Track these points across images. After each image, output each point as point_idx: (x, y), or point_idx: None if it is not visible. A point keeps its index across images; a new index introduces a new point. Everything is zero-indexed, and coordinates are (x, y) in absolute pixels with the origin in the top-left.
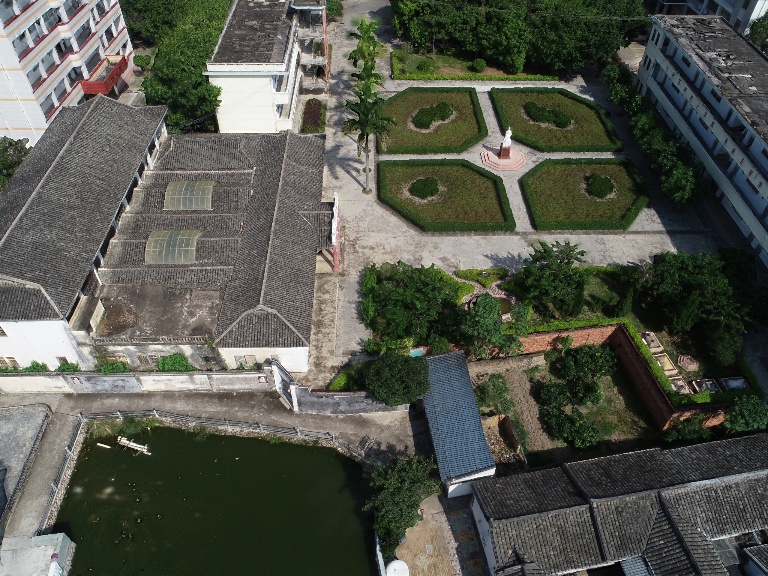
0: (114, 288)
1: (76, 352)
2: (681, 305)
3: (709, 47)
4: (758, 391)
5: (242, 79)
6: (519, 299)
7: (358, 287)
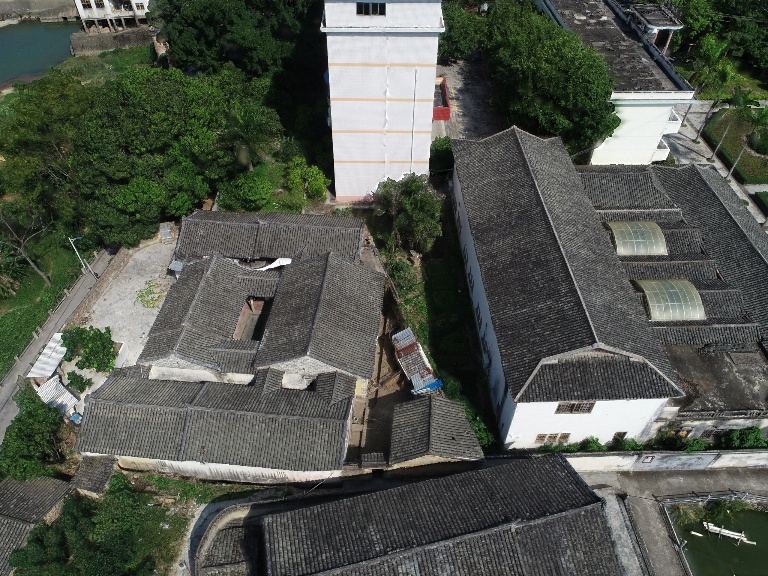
0: None
1: (644, 427)
2: None
3: None
4: None
5: (642, 108)
6: None
7: None
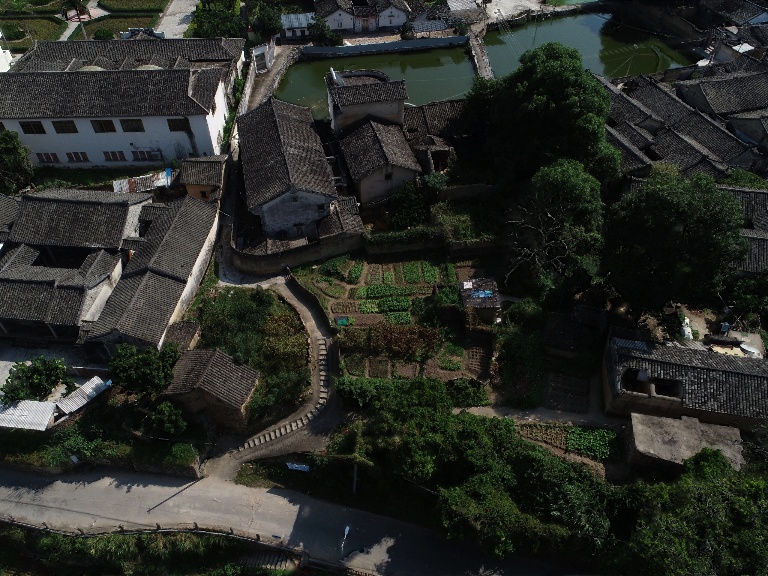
0: None
1: None
2: None
3: None
4: None
5: None
6: None
7: None
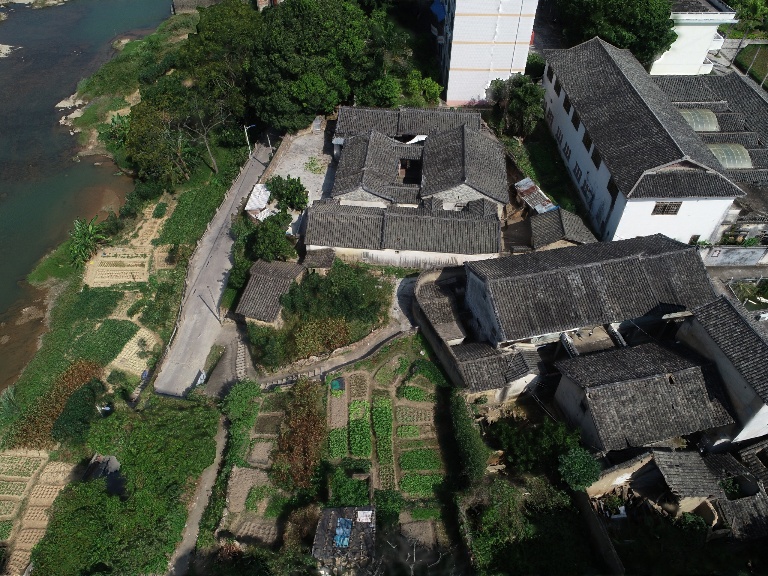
0: None
1: (713, 231)
2: None
3: None
4: None
5: (694, 27)
6: None
7: None
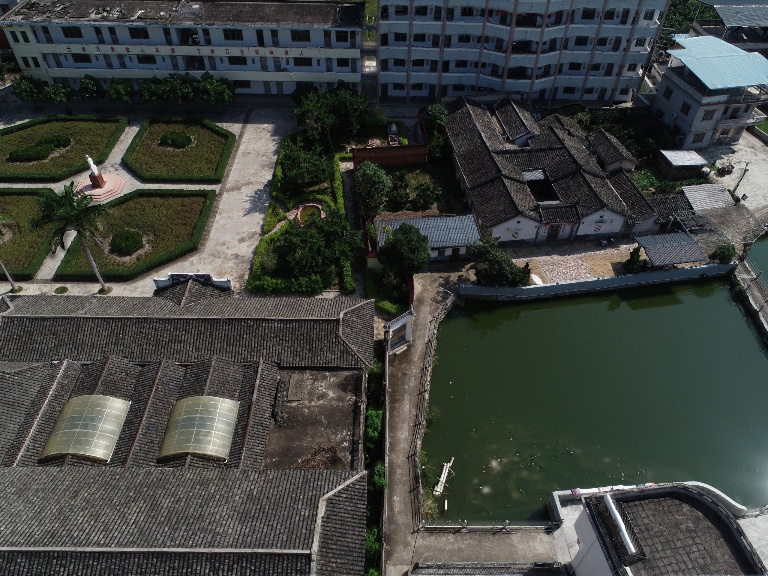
0: None
1: None
2: (349, 118)
3: (83, 13)
4: (400, 122)
5: None
6: (303, 203)
7: None
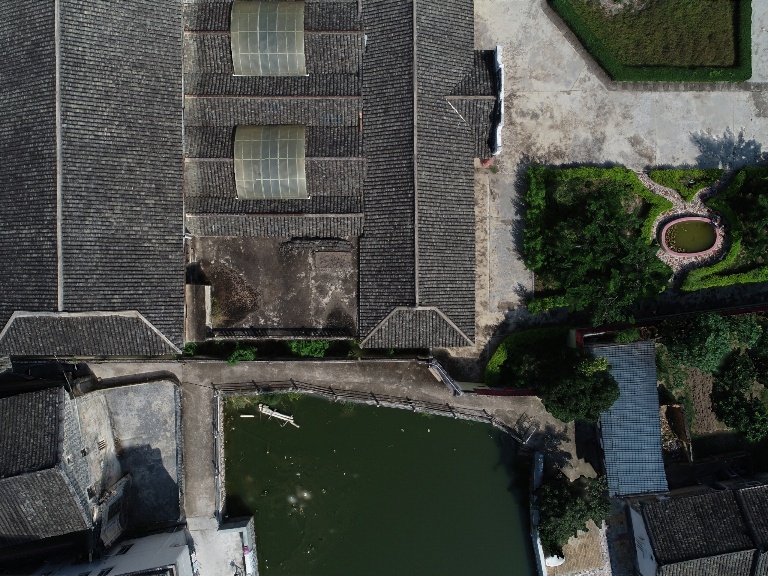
0: (209, 243)
1: None
2: None
3: None
4: None
5: None
6: (725, 221)
7: (515, 194)
